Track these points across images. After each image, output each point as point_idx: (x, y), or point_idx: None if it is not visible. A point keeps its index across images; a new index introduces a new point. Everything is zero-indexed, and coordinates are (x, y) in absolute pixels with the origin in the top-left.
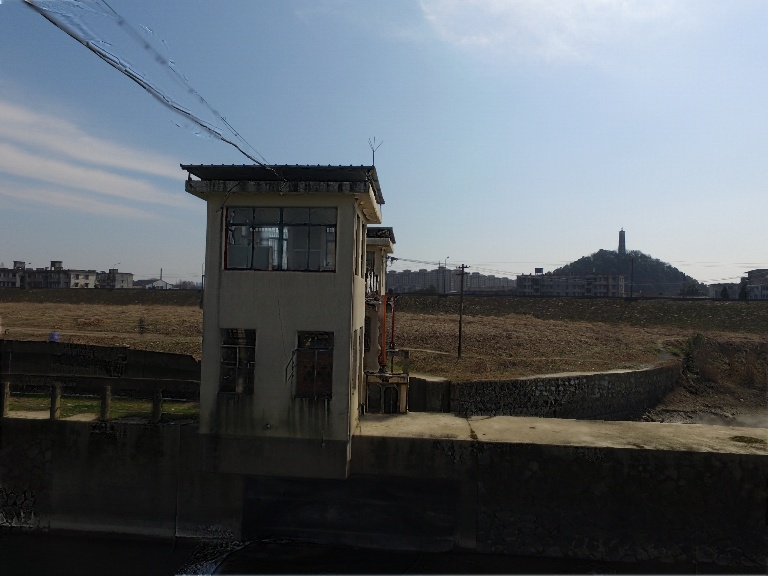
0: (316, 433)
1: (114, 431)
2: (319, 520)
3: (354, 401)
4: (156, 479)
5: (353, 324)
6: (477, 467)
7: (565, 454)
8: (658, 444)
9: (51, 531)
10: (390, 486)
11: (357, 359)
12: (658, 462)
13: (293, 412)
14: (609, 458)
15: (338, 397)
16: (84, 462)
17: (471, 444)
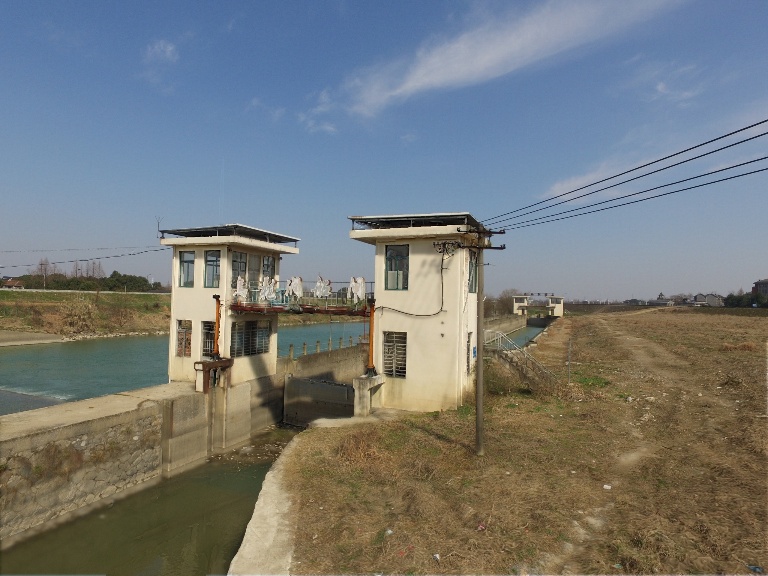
0: None
1: None
2: None
3: (186, 363)
4: None
5: (173, 315)
6: None
7: None
8: None
9: None
10: None
11: (195, 340)
12: None
13: None
14: None
15: None
16: None
17: None
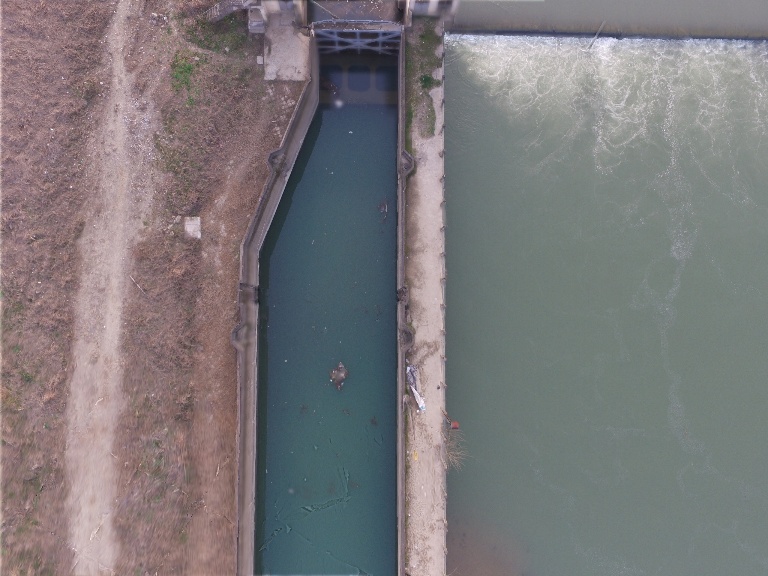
0: None
1: None
2: None
3: None
4: None
5: None
6: None
7: None
8: None
9: None
10: None
11: None
12: None
13: None
14: None
15: None
16: None
17: None
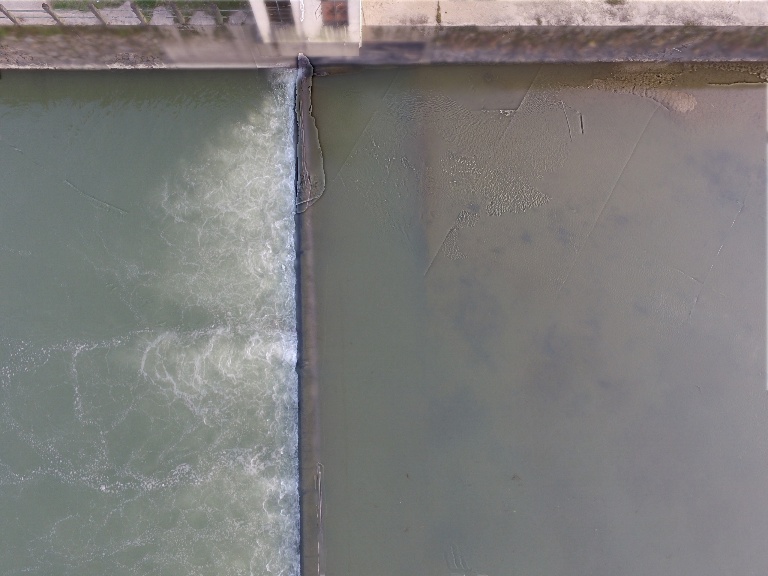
0: (340, 40)
1: (195, 29)
2: (342, 59)
3: None
4: (235, 48)
5: None
6: (437, 36)
7: (492, 30)
8: (553, 16)
9: (180, 69)
10: (384, 46)
11: None
12: (545, 31)
13: (324, 32)
14: (517, 30)
15: (353, 25)
16: (182, 43)
17: (436, 27)
